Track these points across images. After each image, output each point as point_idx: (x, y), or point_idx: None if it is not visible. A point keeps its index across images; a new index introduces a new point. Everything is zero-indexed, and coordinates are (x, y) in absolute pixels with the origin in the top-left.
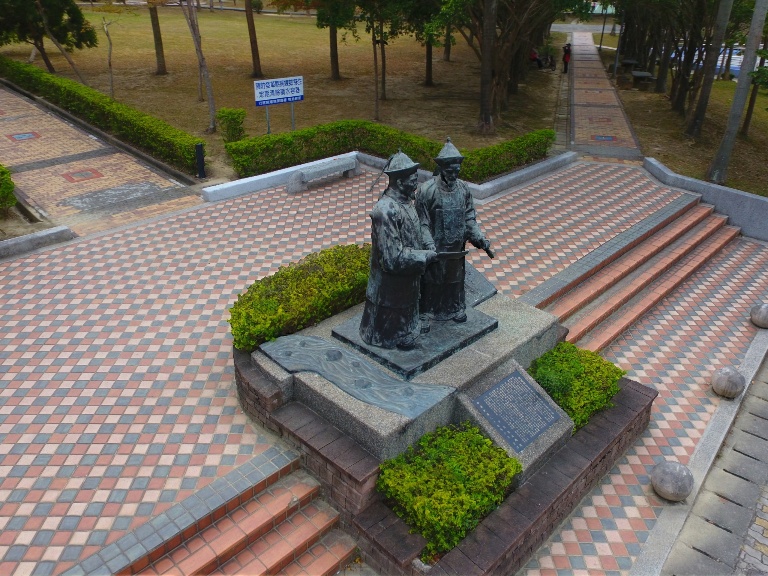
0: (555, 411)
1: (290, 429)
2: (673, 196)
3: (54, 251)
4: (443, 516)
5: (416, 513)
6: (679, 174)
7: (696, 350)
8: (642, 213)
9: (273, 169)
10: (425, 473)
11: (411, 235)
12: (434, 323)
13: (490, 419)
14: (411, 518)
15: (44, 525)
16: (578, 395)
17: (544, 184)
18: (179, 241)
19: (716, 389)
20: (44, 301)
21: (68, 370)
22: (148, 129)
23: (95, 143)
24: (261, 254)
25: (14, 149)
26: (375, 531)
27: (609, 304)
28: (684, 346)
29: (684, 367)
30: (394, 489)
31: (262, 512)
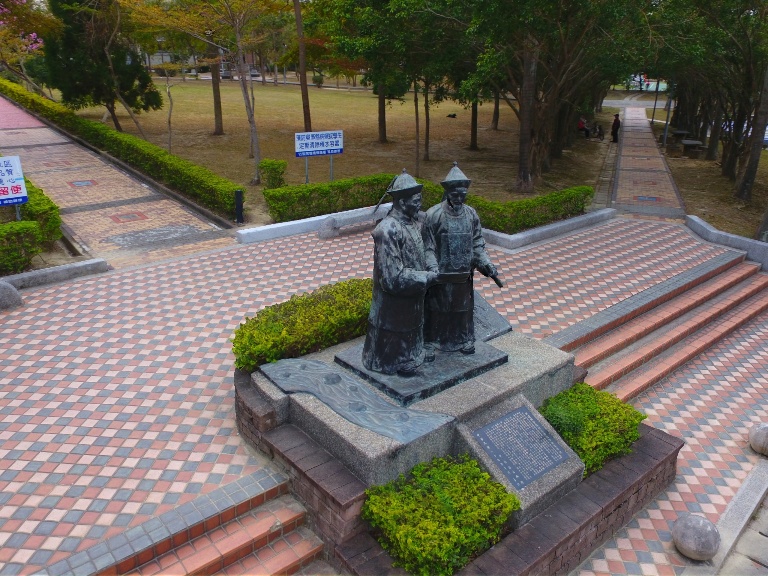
0: (564, 451)
1: (280, 450)
2: (715, 252)
3: (88, 281)
4: (426, 547)
5: (399, 543)
6: (722, 231)
7: (734, 406)
8: (680, 267)
9: (308, 217)
10: (413, 502)
11: (413, 256)
12: (440, 353)
13: (490, 452)
14: (395, 550)
15: (21, 528)
16: (591, 436)
17: (579, 237)
18: (207, 276)
19: (754, 446)
20: (69, 324)
21: (77, 386)
22: (194, 177)
23: (146, 191)
24: (283, 291)
25: (72, 194)
26: (356, 562)
27: (639, 354)
28: (721, 401)
29: (719, 422)
30: (378, 516)
31: (242, 534)
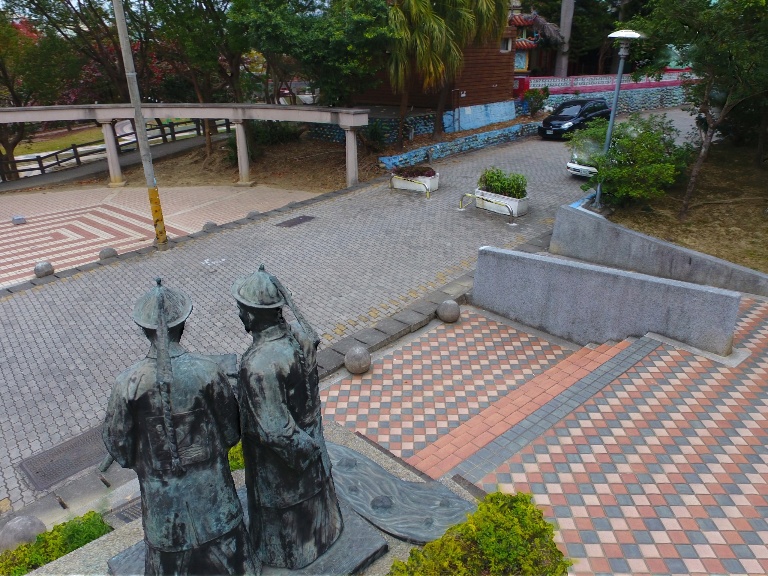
0: None
1: None
2: None
3: None
4: None
5: None
6: None
7: None
8: None
9: None
10: None
11: None
12: None
13: None
14: None
15: (614, 439)
16: None
17: None
18: None
19: None
20: None
21: None
22: None
23: None
24: None
25: None
26: None
27: None
28: None
29: None
30: None
31: (445, 468)
